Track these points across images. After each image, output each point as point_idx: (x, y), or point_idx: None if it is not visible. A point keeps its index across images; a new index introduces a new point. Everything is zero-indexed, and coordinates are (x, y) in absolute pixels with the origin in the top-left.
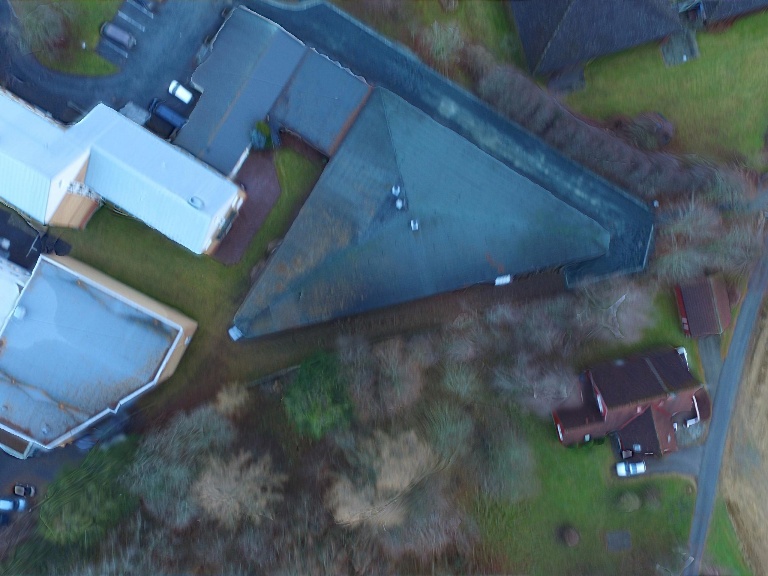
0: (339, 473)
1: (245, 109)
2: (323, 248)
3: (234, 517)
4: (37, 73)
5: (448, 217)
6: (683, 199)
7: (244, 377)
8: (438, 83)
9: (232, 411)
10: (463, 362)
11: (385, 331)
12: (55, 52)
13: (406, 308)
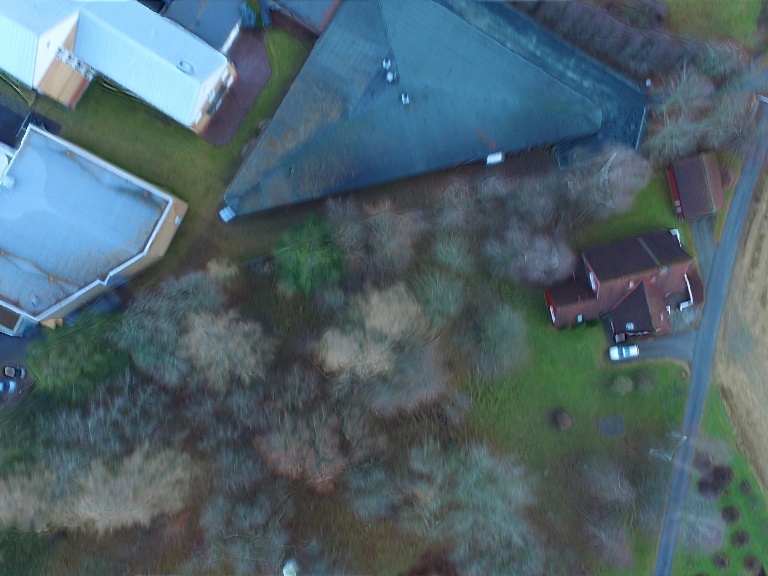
0: (328, 326)
1: None
2: (314, 123)
3: (223, 377)
4: None
5: (439, 91)
6: (675, 70)
7: (235, 257)
8: None
9: (222, 279)
10: (454, 233)
11: (376, 212)
12: None
13: (397, 189)
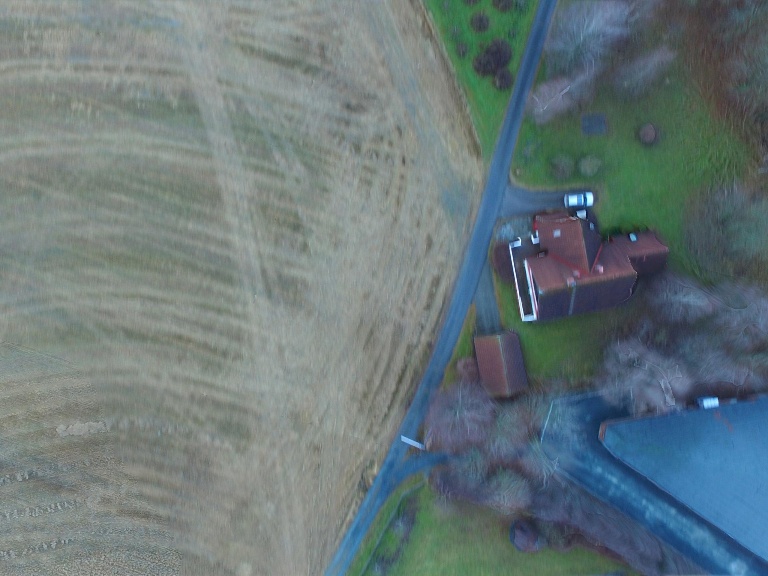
0: None
1: None
2: None
3: None
4: None
5: None
6: None
7: None
8: None
9: None
10: None
11: None
12: None
13: None
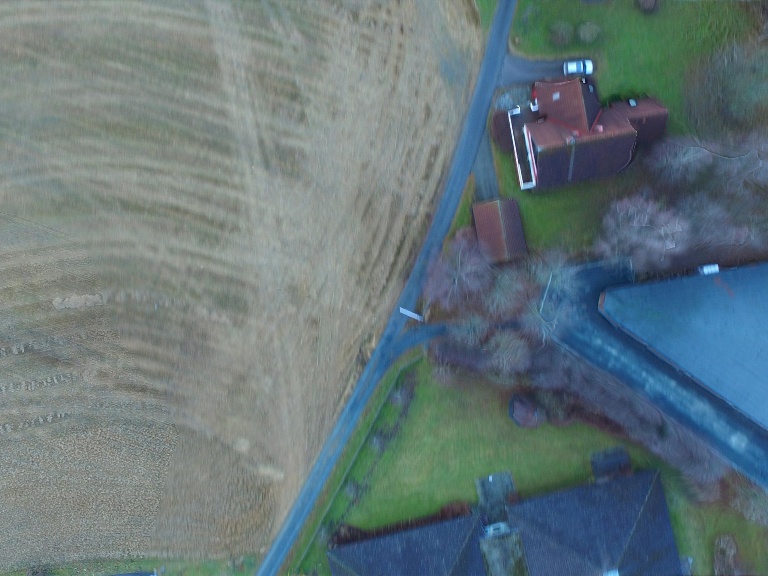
0: None
1: None
2: None
3: None
4: None
5: None
6: None
7: None
8: (747, 466)
9: None
10: None
11: None
12: None
13: None
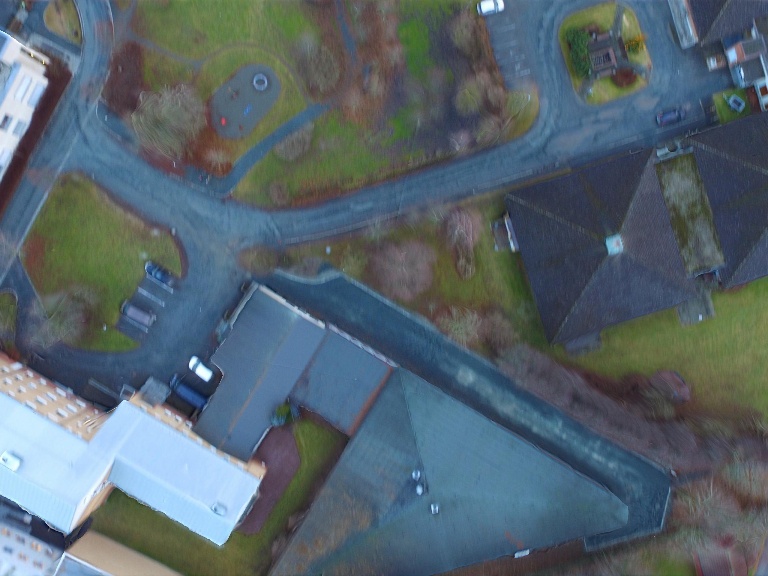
0: None
1: (266, 395)
2: (344, 530)
3: None
4: (58, 350)
5: (468, 499)
6: (702, 485)
7: None
8: (456, 352)
9: None
10: None
11: None
12: (76, 334)
13: None
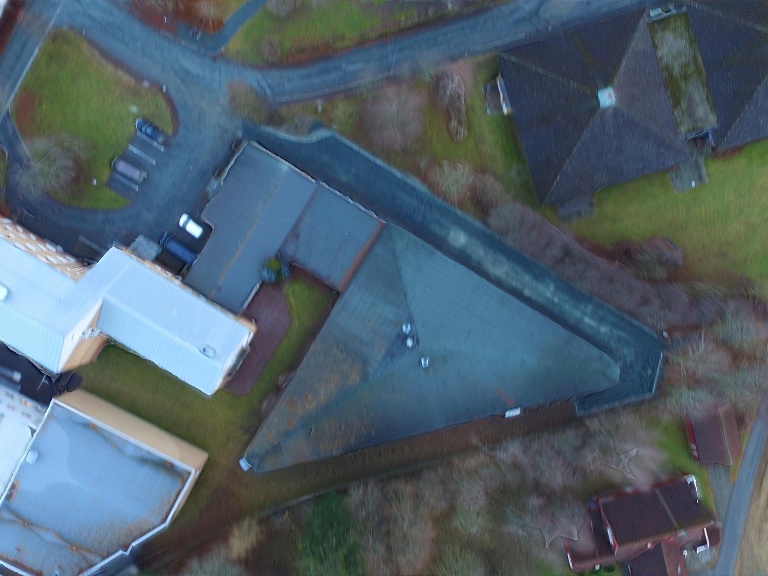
0: None
1: (256, 247)
2: (334, 385)
3: None
4: (48, 207)
5: (458, 354)
6: (693, 338)
7: (255, 509)
8: (447, 213)
9: (244, 556)
10: (474, 503)
11: (395, 461)
12: (66, 189)
13: (416, 438)
